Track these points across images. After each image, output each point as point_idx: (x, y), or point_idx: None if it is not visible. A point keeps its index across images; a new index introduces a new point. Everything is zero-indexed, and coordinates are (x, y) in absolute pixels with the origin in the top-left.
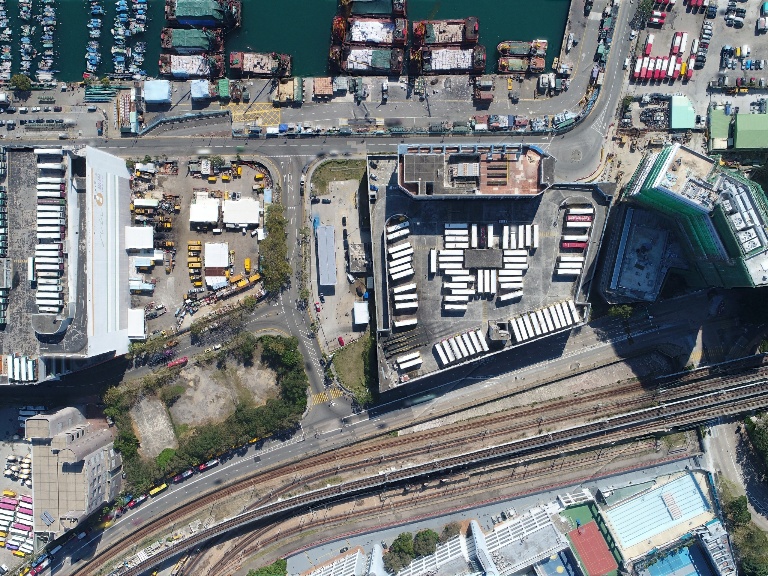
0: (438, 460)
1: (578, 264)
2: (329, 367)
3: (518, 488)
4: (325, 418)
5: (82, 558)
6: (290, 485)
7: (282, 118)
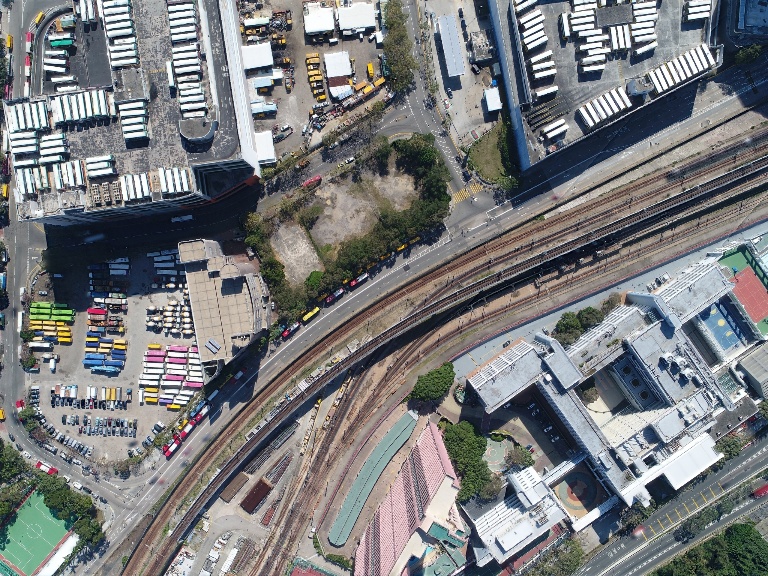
0: (592, 231)
1: (706, 7)
2: (466, 163)
3: (668, 252)
4: (469, 215)
5: (240, 401)
6: (444, 288)
7: None
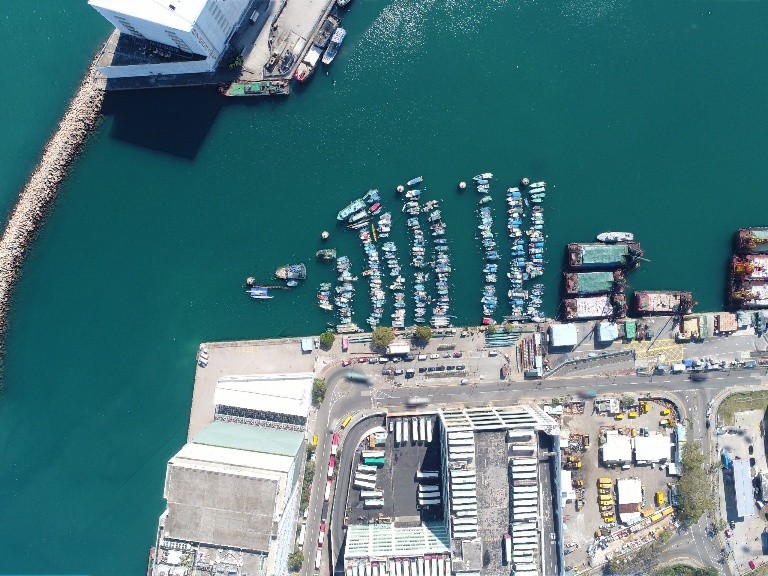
0: None
1: None
2: None
3: None
4: None
5: None
6: None
7: (685, 353)
